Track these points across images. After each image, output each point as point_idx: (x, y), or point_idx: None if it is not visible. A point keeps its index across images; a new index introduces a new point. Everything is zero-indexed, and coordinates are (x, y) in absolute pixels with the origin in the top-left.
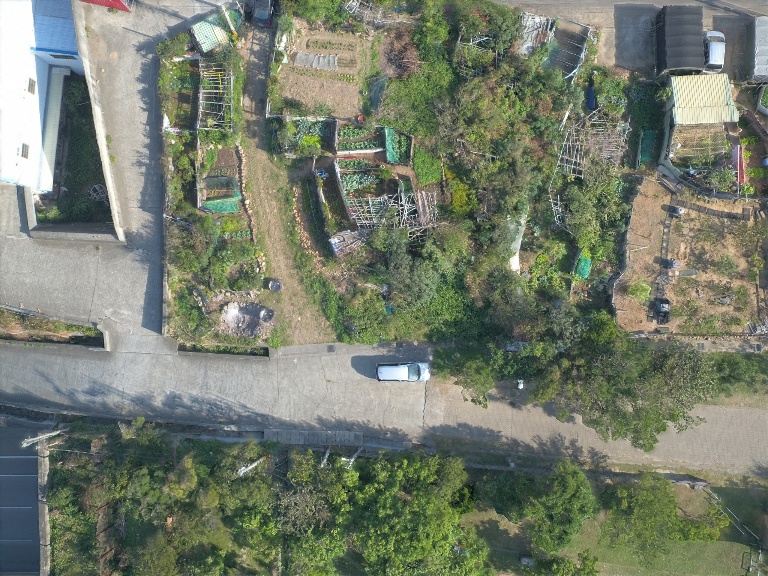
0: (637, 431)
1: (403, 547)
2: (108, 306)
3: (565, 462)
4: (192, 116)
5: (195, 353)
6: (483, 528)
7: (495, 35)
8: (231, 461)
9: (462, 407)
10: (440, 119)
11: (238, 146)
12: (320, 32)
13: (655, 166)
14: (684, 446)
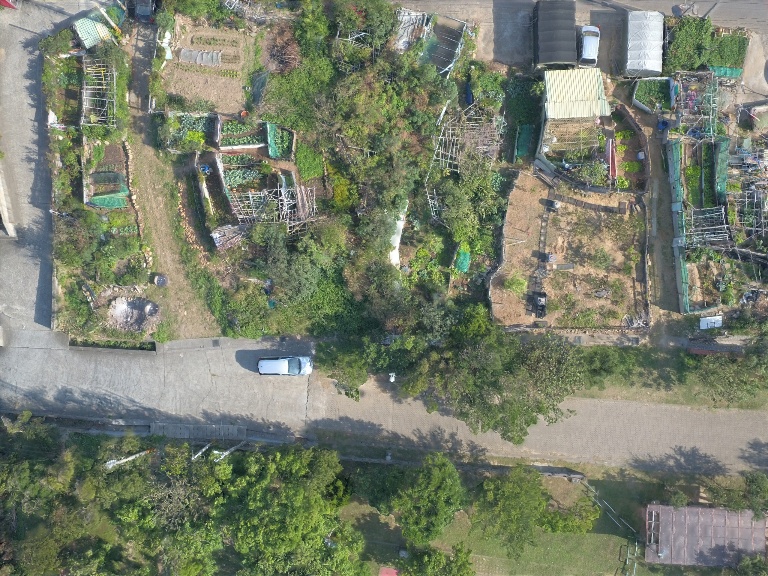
0: (505, 424)
1: (272, 539)
2: (1, 301)
3: (436, 455)
4: (79, 112)
5: (86, 348)
6: (364, 521)
7: (372, 30)
8: (108, 454)
9: (344, 401)
10: (318, 114)
11: (124, 142)
12: (204, 28)
13: (532, 160)
14: (562, 439)
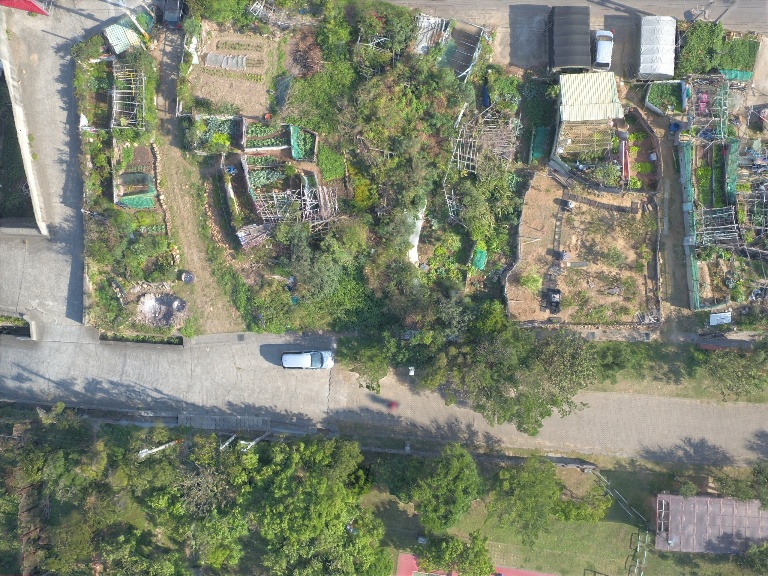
0: (520, 416)
1: (296, 525)
2: (34, 297)
3: (453, 445)
4: (109, 115)
5: (115, 342)
6: (384, 509)
7: (392, 36)
8: (140, 444)
9: (364, 393)
10: (340, 117)
11: (153, 144)
12: (229, 34)
13: (547, 161)
14: (575, 431)
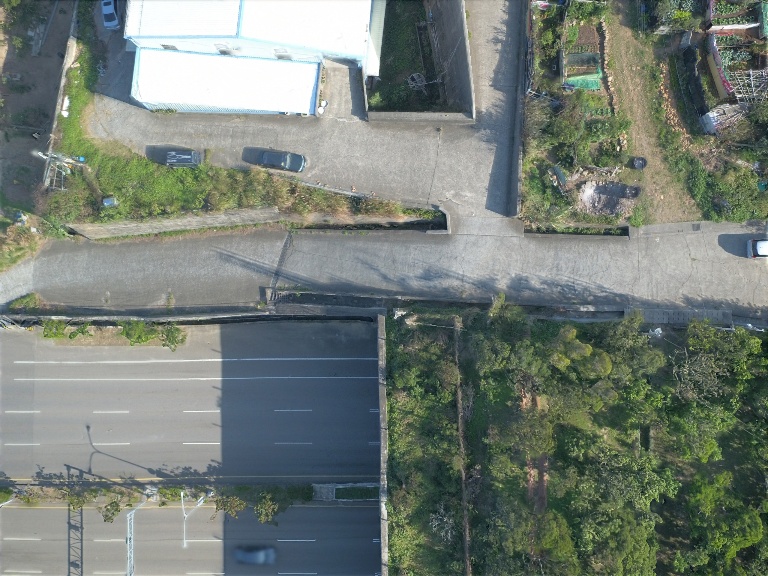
0: None
1: None
2: (449, 188)
3: None
4: None
5: (544, 235)
6: None
7: None
8: (622, 330)
9: None
10: None
11: (602, 22)
12: None
13: None
14: None
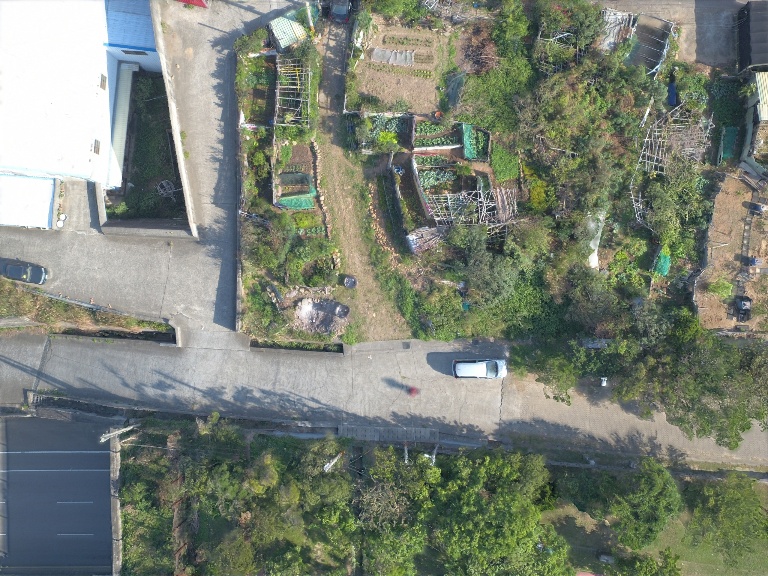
0: (723, 429)
1: (488, 544)
2: (180, 302)
3: (649, 460)
4: (267, 112)
5: (268, 349)
6: (560, 525)
7: (576, 31)
8: (311, 457)
9: (539, 404)
10: (520, 115)
11: (313, 142)
12: (397, 28)
13: (737, 163)
14: (764, 444)
